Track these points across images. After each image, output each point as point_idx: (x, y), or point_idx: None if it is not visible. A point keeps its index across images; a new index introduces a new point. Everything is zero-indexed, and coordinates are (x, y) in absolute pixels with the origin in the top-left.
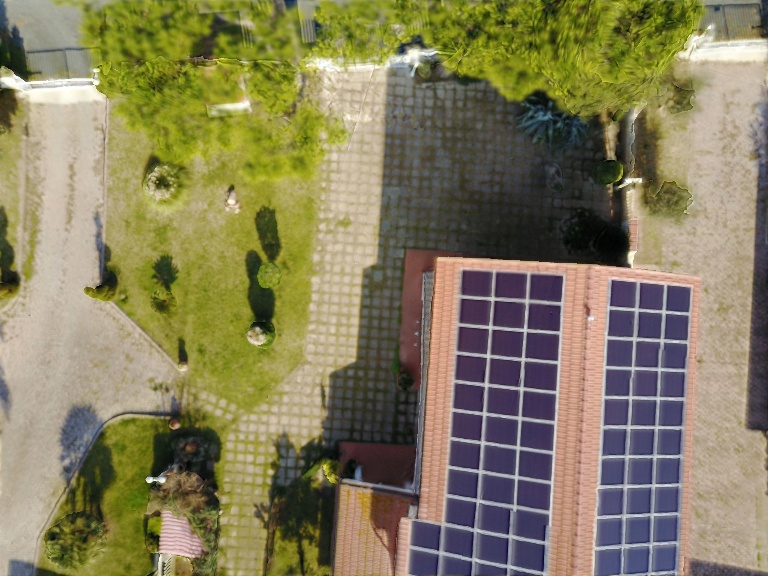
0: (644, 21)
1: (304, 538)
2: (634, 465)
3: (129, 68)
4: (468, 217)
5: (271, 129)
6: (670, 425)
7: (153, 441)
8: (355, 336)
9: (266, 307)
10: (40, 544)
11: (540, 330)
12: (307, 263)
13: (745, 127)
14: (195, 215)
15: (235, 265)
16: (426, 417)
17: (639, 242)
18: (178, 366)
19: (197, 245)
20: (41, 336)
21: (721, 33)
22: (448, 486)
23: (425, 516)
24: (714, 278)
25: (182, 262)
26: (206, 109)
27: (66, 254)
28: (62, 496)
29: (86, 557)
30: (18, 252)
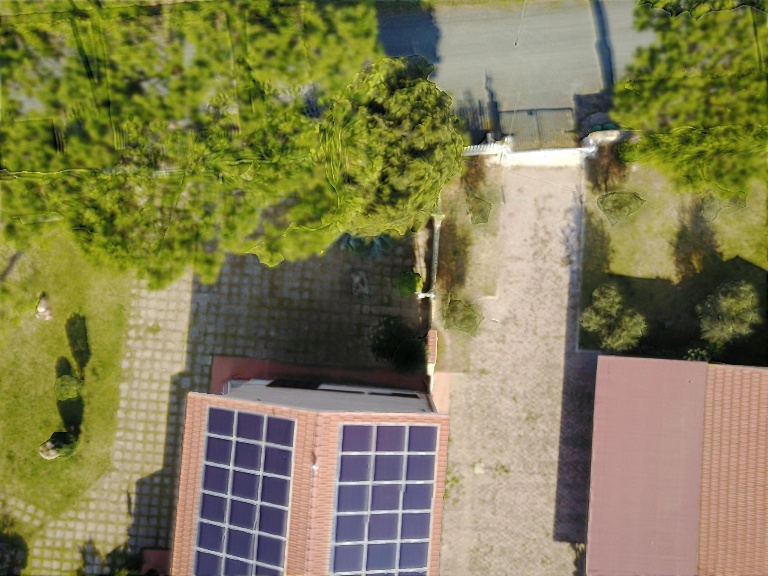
0: (386, 160)
1: None
2: None
3: None
4: (276, 324)
5: None
6: (413, 568)
7: None
8: (162, 443)
9: (75, 413)
10: None
11: (274, 474)
12: (116, 369)
13: (556, 233)
14: (6, 322)
15: (45, 371)
16: (174, 554)
17: (447, 350)
18: None
19: (8, 351)
20: None
21: (533, 138)
22: None
23: None
24: (523, 387)
25: None
26: None
27: None
28: None
29: None
30: None
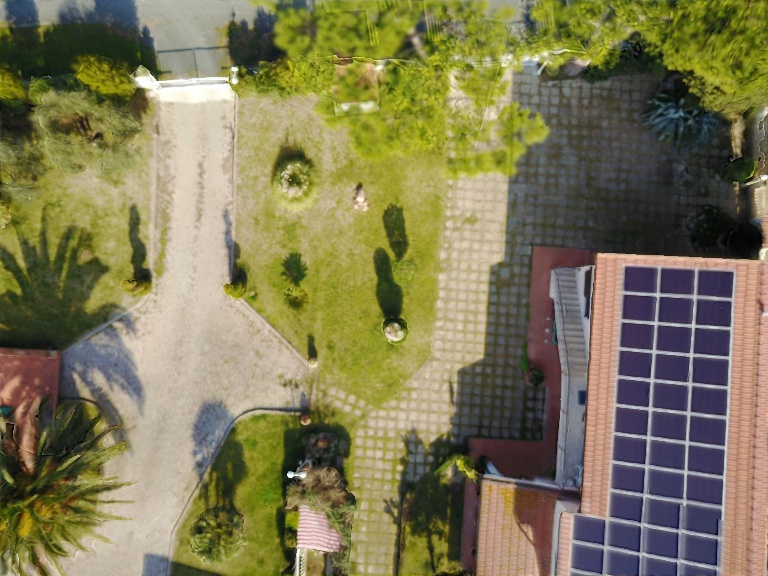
0: None
1: (434, 533)
2: None
3: (267, 67)
4: (594, 214)
5: (398, 127)
6: None
7: (283, 437)
8: (483, 333)
9: (394, 304)
10: (174, 538)
11: (709, 326)
12: (434, 260)
13: None
14: (324, 213)
15: (363, 262)
16: (588, 412)
17: None
18: (310, 362)
19: (326, 242)
20: (172, 332)
21: None
22: (612, 481)
23: (588, 510)
24: None
25: (311, 259)
26: (333, 107)
27: (196, 251)
28: (195, 491)
29: (231, 551)
30: (150, 249)
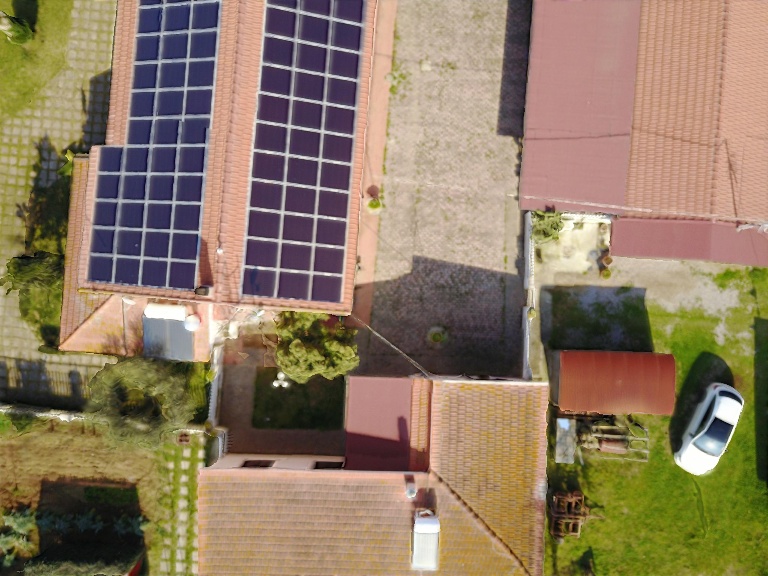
0: None
1: (64, 236)
2: (301, 79)
3: None
4: None
5: None
6: (344, 48)
7: None
8: None
9: (30, 14)
10: None
11: None
12: None
13: None
14: None
15: None
16: (114, 47)
17: None
18: None
19: None
20: None
21: None
22: (131, 109)
23: (111, 141)
24: None
25: None
26: None
27: None
28: None
29: None
30: None
